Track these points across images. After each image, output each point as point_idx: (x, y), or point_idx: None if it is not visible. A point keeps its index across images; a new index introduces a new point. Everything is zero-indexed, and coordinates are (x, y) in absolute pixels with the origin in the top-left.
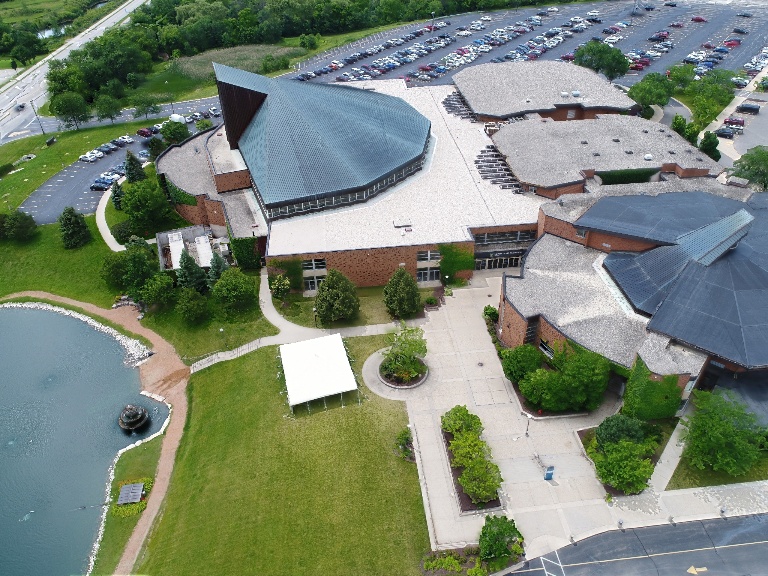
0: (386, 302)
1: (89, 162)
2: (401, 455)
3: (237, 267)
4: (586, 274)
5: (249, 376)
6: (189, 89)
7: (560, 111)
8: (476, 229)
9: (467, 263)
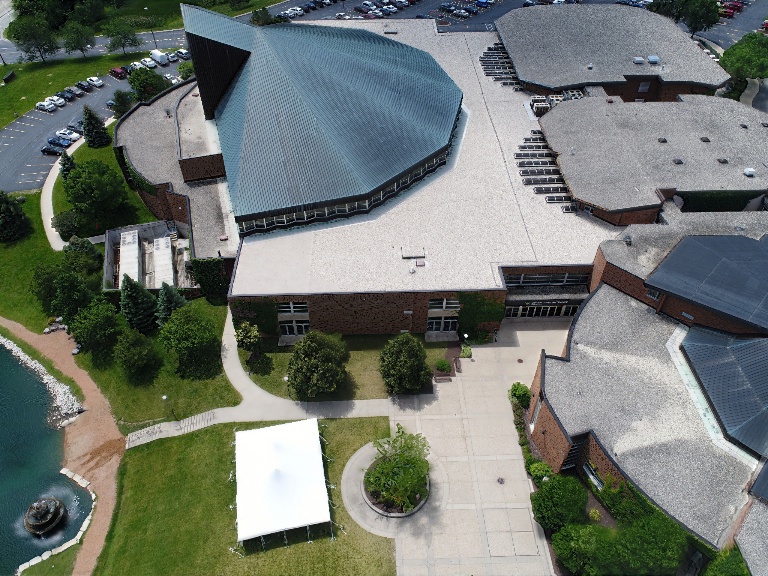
0: (382, 373)
1: (47, 112)
2: None
3: (200, 291)
4: (657, 361)
5: (194, 471)
6: None
7: (630, 83)
8: (510, 269)
9: (494, 314)
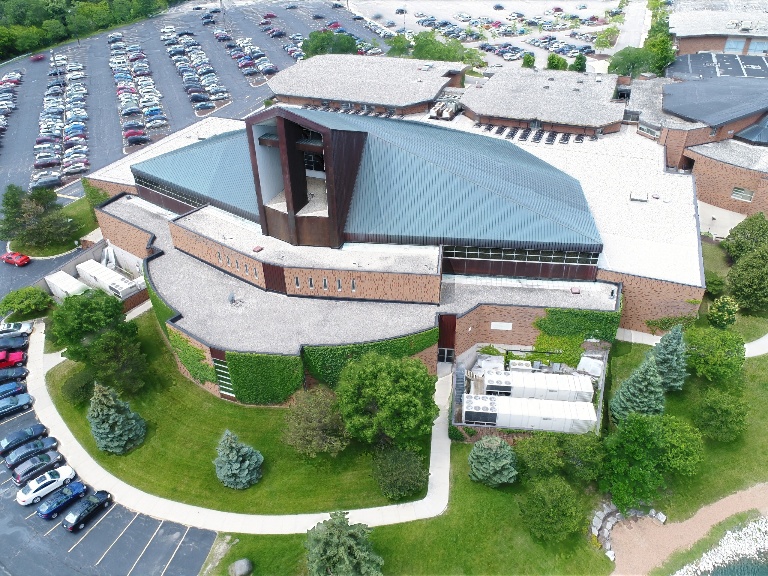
0: None
1: None
2: None
3: None
4: (765, 153)
5: None
6: None
7: None
8: None
9: None
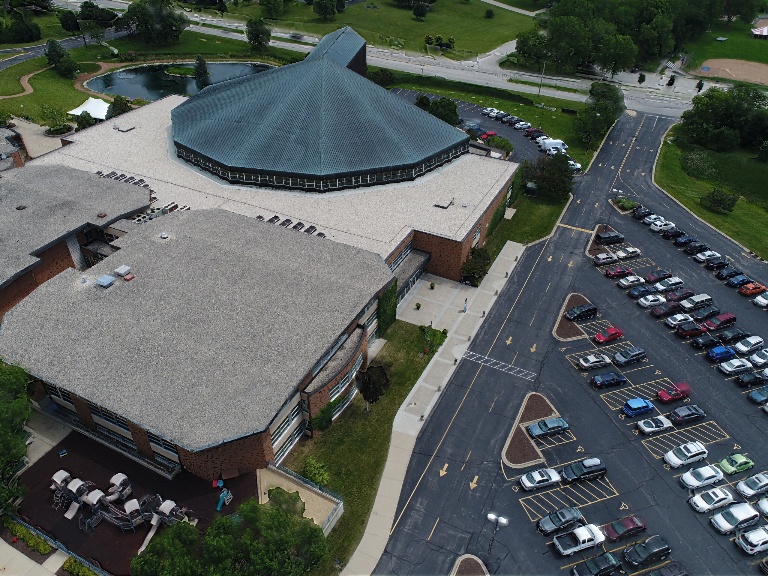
0: None
1: None
2: (26, 116)
3: None
4: None
5: None
6: (741, 190)
7: None
8: None
9: None
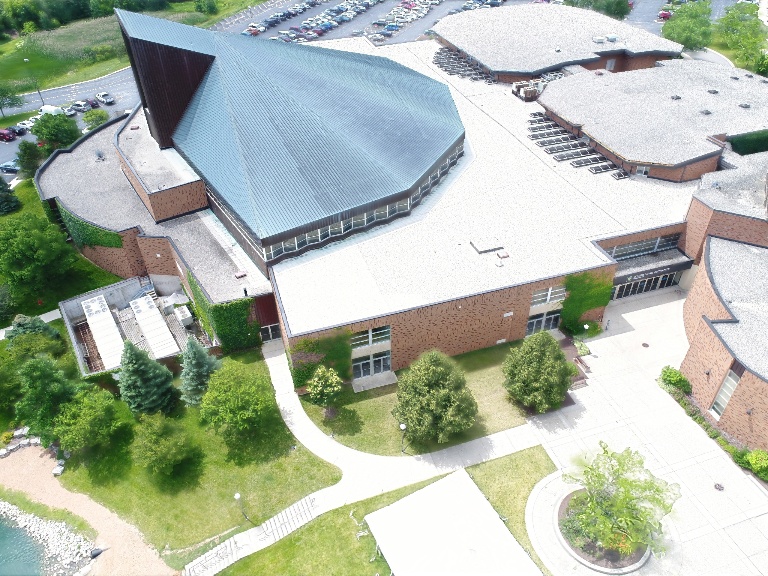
0: (517, 391)
1: None
2: None
3: (220, 349)
4: None
5: None
6: (57, 72)
7: (598, 61)
8: (604, 242)
9: (601, 297)
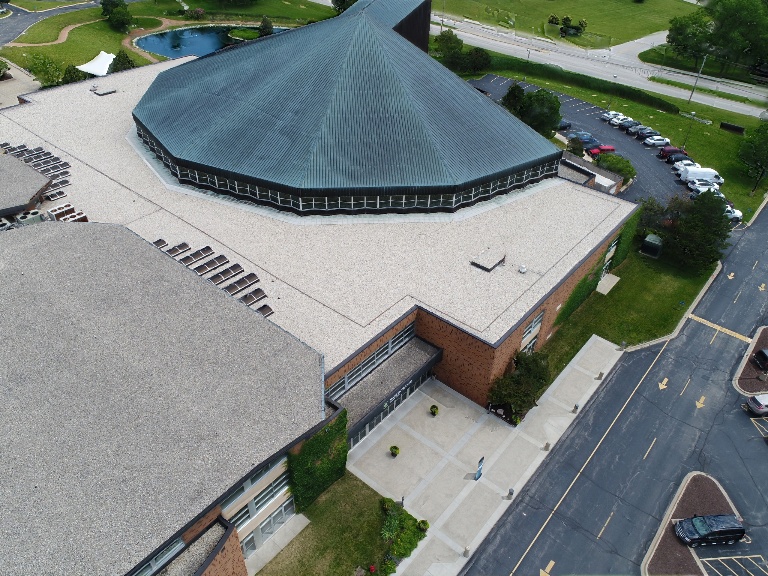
0: None
1: None
2: None
3: None
4: None
5: None
6: None
7: None
8: None
9: None
